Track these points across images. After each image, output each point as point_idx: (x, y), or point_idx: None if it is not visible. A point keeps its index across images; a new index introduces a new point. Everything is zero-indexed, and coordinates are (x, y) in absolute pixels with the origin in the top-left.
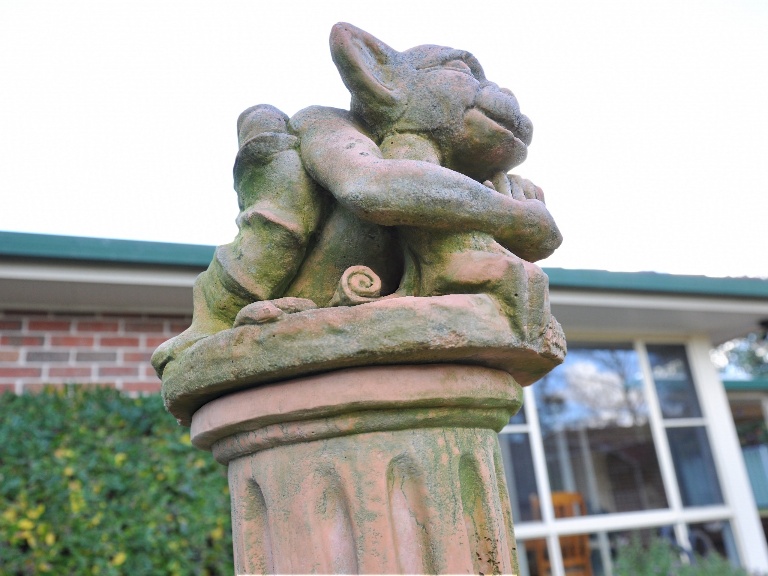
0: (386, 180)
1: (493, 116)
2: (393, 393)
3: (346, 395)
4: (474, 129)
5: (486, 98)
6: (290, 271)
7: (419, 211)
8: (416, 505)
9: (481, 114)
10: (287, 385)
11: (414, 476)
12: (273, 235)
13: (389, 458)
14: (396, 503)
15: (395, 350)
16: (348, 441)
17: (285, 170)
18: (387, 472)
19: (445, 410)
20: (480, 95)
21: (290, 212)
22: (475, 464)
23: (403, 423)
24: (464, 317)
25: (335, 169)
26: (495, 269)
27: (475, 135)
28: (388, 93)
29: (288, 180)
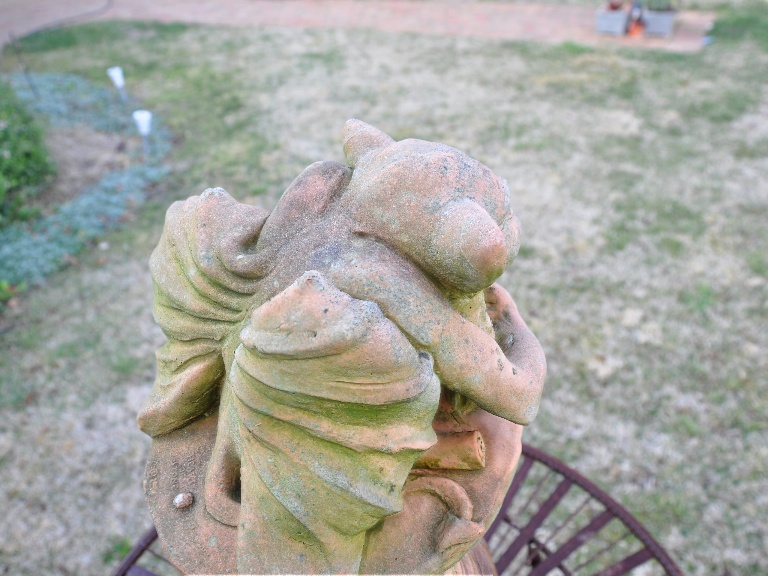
0: None
1: None
2: None
3: None
4: None
5: None
6: None
7: None
8: None
9: None
10: None
11: None
12: None
13: None
14: None
15: None
16: None
17: None
18: None
19: None
20: None
21: None
22: None
23: None
24: None
25: (502, 398)
26: None
27: None
28: None
29: None
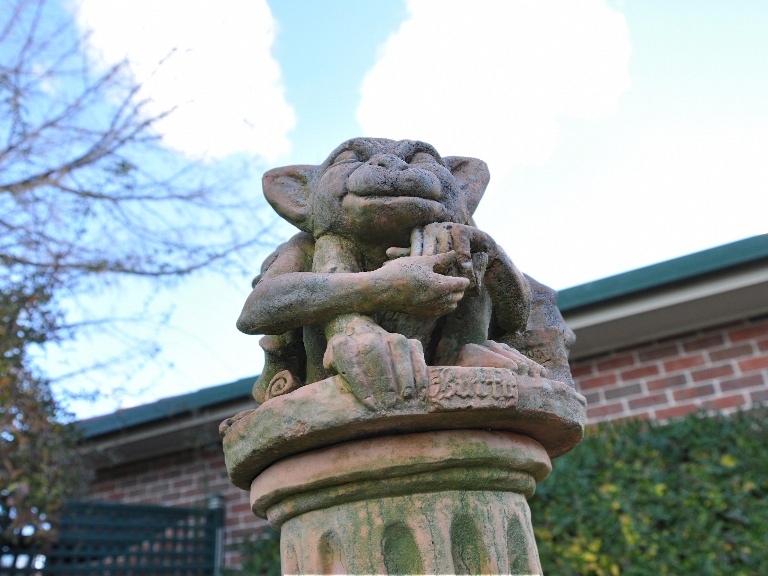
0: (249, 306)
1: (361, 194)
2: (296, 479)
3: (271, 485)
4: (352, 213)
5: (351, 181)
6: None
7: (276, 321)
8: None
9: (351, 197)
10: (254, 480)
11: None
12: None
13: (320, 534)
14: (337, 574)
15: (268, 446)
16: (298, 521)
17: None
18: (320, 547)
19: (354, 485)
20: (348, 180)
21: None
22: (410, 532)
23: (323, 502)
24: (306, 406)
25: None
26: None
27: (355, 217)
28: (297, 213)
29: None
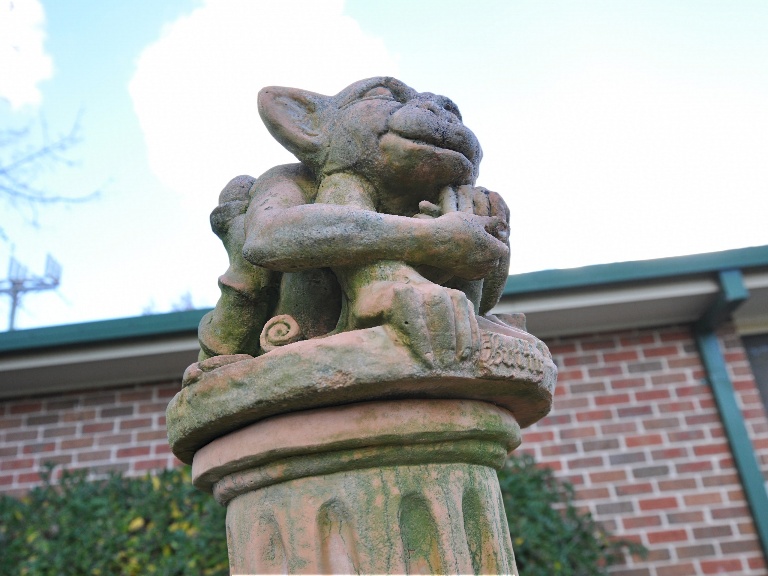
0: (270, 232)
1: (407, 135)
2: (305, 438)
3: (264, 444)
4: (391, 154)
5: (397, 119)
6: (253, 327)
7: (307, 255)
8: (352, 550)
9: (394, 137)
10: (224, 438)
11: (348, 520)
12: (229, 297)
13: (320, 503)
14: (334, 548)
15: (286, 397)
16: (284, 488)
17: (236, 235)
18: (318, 517)
19: (373, 450)
20: (392, 118)
21: (241, 273)
22: (426, 504)
23: (329, 467)
24: (350, 355)
25: None
26: (386, 299)
27: (393, 159)
28: (308, 141)
29: (238, 243)
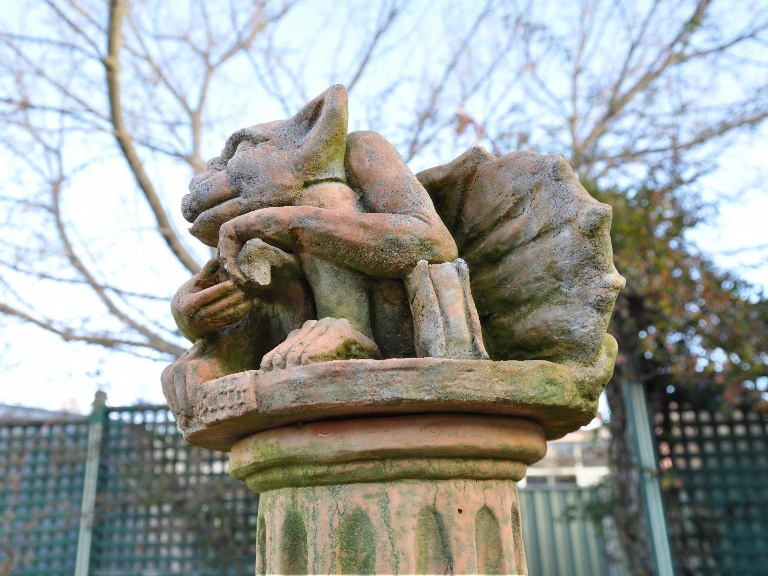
0: None
1: None
2: None
3: None
4: None
5: None
6: None
7: None
8: None
9: None
10: None
11: None
12: None
13: None
14: None
15: None
16: None
17: None
18: None
19: None
20: None
21: None
22: None
23: None
24: None
25: None
26: None
27: None
28: None
29: None
